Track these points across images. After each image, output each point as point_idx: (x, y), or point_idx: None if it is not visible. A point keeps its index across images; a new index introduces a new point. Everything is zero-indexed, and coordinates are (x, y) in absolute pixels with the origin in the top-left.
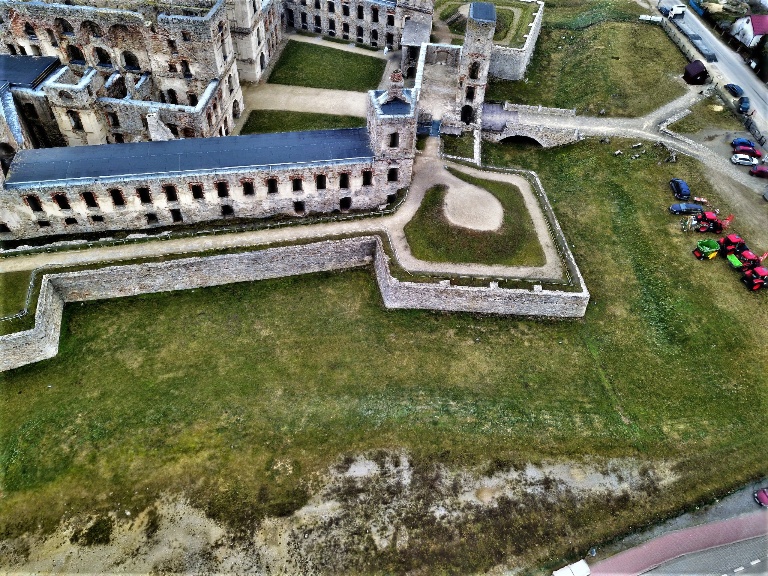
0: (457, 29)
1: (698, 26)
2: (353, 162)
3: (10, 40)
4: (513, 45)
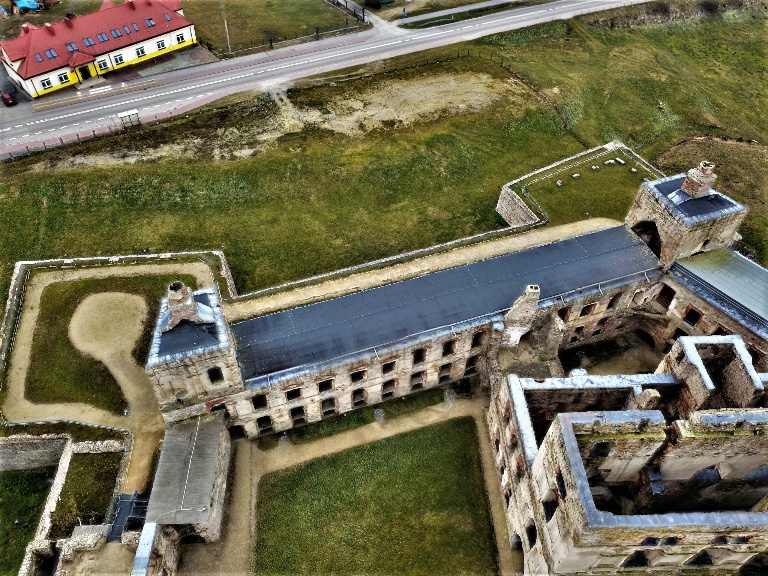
0: None
1: None
2: None
3: None
4: None
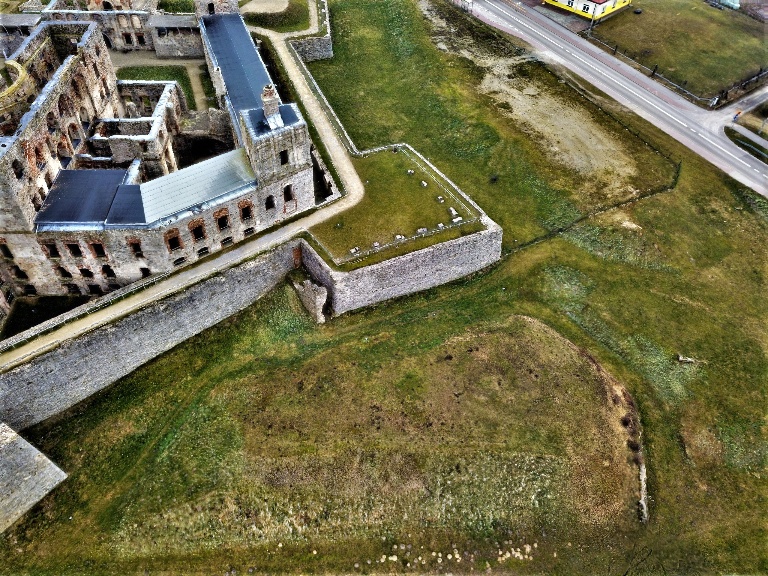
0: None
1: None
2: (243, 22)
3: (33, 191)
4: None
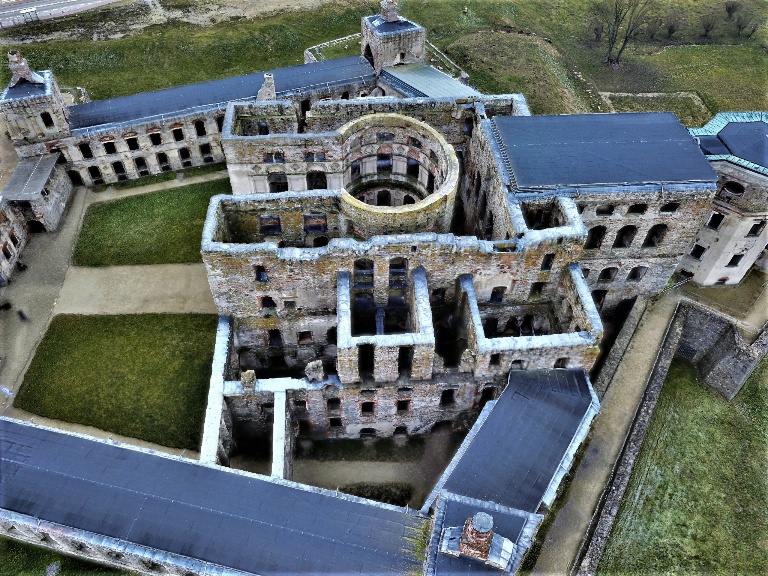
0: None
1: None
2: None
3: None
4: None
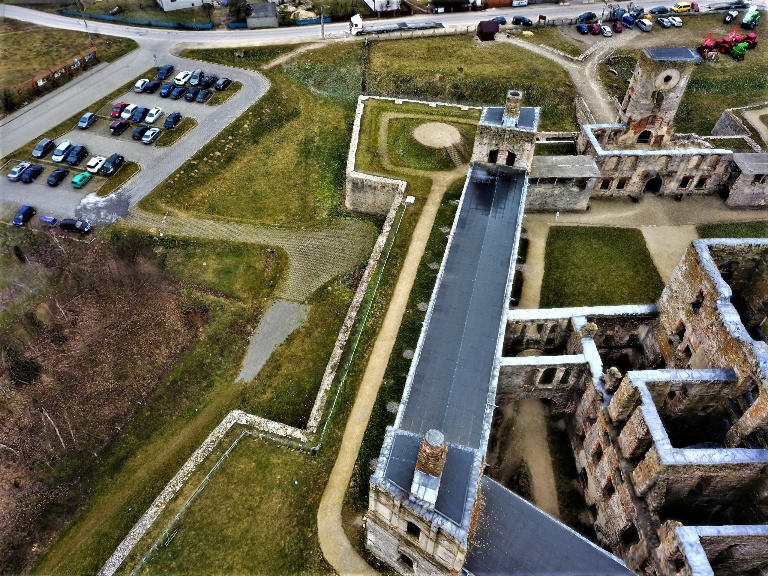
0: None
1: (364, 24)
2: None
3: None
4: None
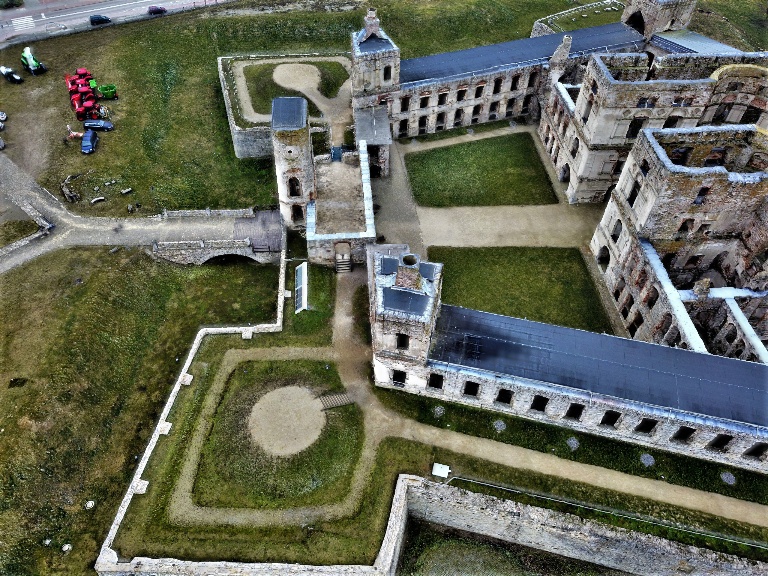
0: (324, 377)
1: None
2: None
3: None
4: (218, 351)
